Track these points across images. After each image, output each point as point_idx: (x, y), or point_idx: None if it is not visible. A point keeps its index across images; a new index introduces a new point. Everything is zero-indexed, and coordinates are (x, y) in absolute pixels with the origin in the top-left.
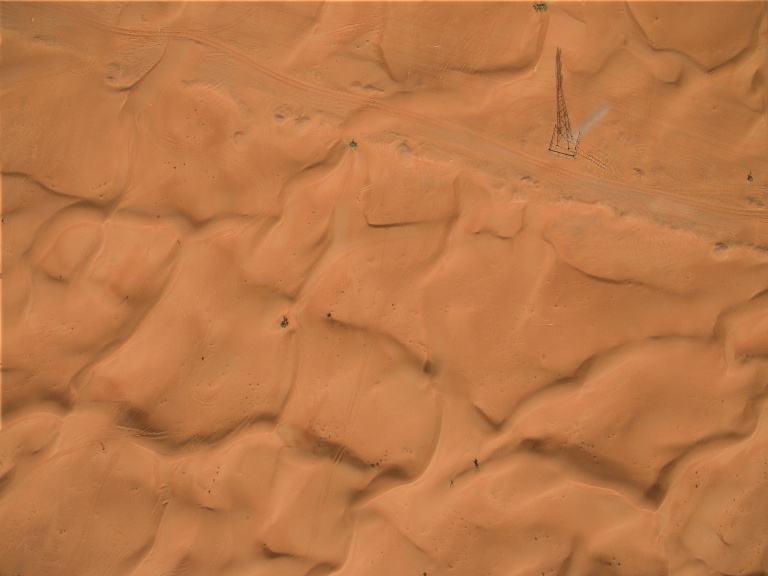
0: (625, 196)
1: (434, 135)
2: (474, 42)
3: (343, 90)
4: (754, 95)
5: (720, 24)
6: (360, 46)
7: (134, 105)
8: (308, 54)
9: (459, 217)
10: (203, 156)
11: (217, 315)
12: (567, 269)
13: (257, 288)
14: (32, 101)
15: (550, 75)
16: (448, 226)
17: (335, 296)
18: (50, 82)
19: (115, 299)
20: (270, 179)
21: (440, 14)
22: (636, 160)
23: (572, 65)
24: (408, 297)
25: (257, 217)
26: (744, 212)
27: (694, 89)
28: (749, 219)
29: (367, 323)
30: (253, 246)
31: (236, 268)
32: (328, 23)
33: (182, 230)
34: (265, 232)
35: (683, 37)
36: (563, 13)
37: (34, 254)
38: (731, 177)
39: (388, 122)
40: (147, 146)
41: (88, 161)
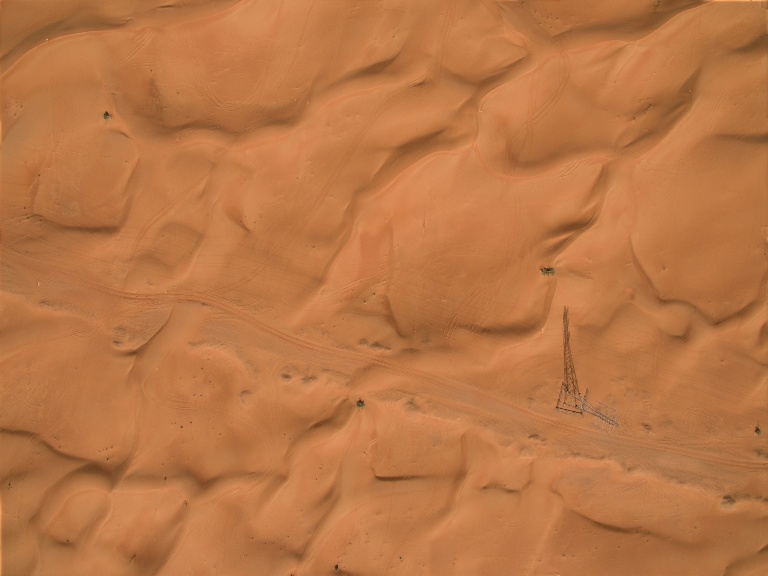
0: (633, 451)
1: (441, 394)
2: (481, 299)
3: (350, 348)
4: (762, 349)
5: (727, 277)
6: (367, 300)
7: (141, 371)
8: (315, 314)
9: (466, 475)
10: (210, 413)
11: (224, 572)
12: (574, 517)
13: (264, 545)
14: (38, 362)
15: (557, 334)
16: (455, 483)
17: (342, 548)
18: (56, 344)
19: (122, 559)
20: (277, 438)
21: (447, 268)
22: (643, 415)
23: (579, 320)
24: (415, 550)
25: (264, 475)
26: (752, 464)
27: (701, 343)
28: (757, 472)
29: (375, 575)
30: (260, 504)
31: (243, 525)
32: (335, 283)
33: (189, 492)
34: (272, 491)
35: (690, 289)
36: (570, 274)
37: (41, 521)
38: (739, 430)
39: (395, 380)
40: (154, 410)
41: (95, 424)
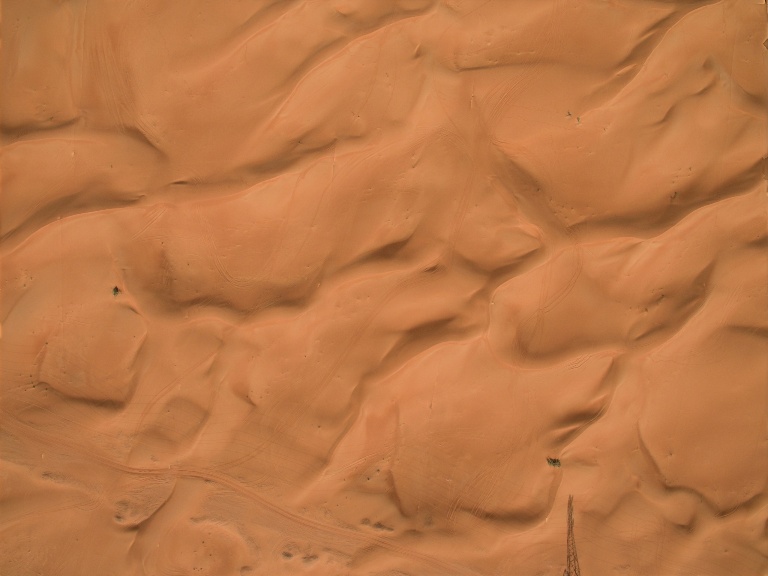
0: None
1: None
2: (485, 482)
3: (352, 528)
4: (767, 541)
5: (735, 468)
6: (370, 477)
7: (142, 548)
8: (318, 493)
9: None
10: None
11: None
12: None
13: None
14: (39, 531)
15: (561, 522)
16: None
17: None
18: (58, 515)
19: None
20: None
21: (452, 448)
22: None
23: (584, 506)
24: None
25: None
26: None
27: (706, 534)
28: None
29: None
30: None
31: None
32: (339, 463)
33: None
34: None
35: (697, 477)
36: (576, 464)
37: None
38: None
39: (396, 562)
40: None
41: None
